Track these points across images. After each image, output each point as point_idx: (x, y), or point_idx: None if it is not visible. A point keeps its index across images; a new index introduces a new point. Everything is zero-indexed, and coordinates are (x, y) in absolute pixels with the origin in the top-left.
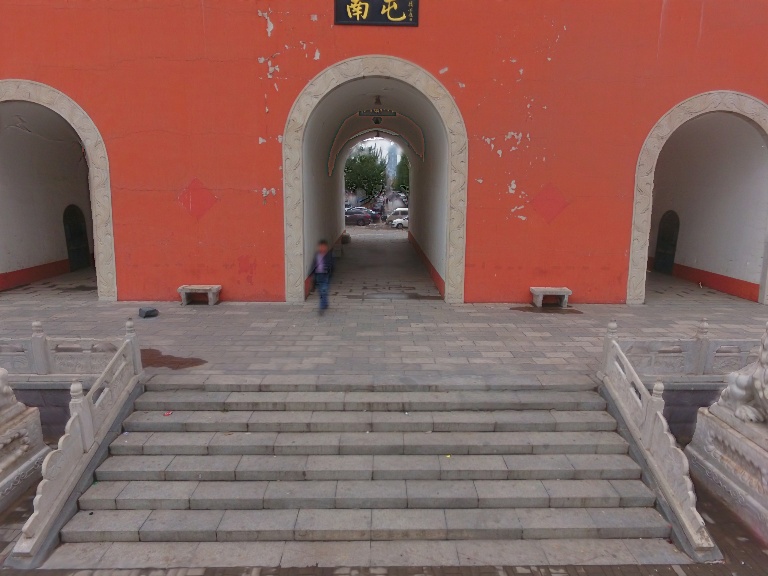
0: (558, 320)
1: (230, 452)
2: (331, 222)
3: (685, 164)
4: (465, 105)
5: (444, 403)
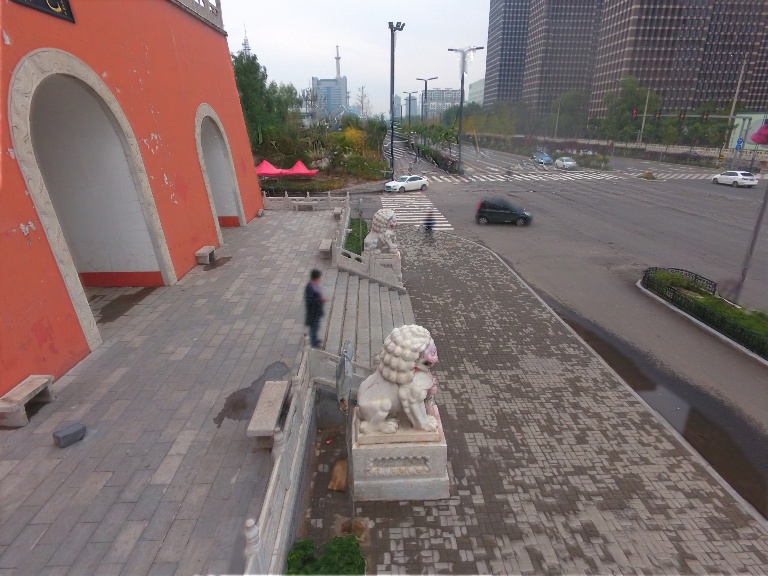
0: (243, 263)
1: None
2: None
3: None
4: (125, 109)
5: None
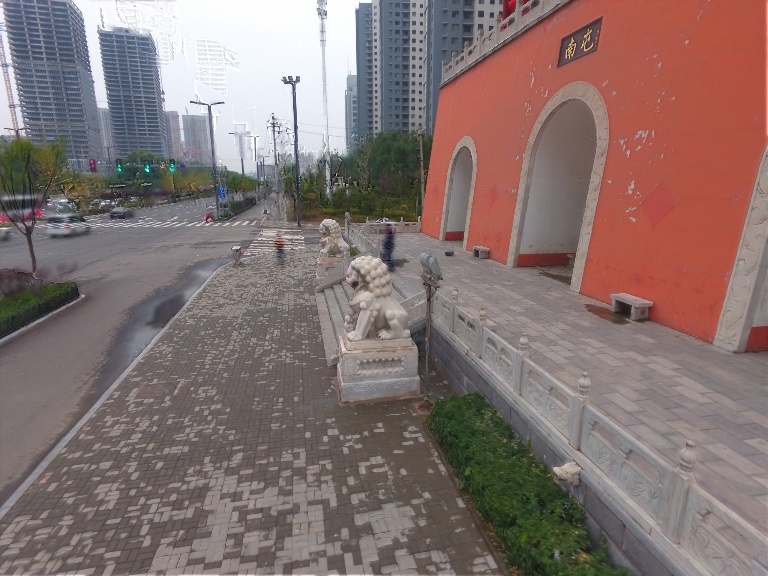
0: (571, 315)
1: None
2: None
3: None
4: (614, 111)
5: None
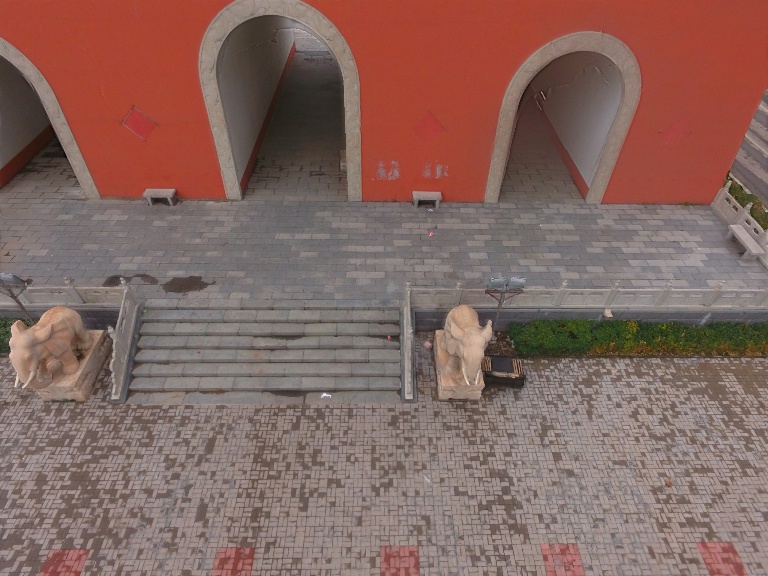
0: None
1: None
2: None
3: None
4: None
5: None
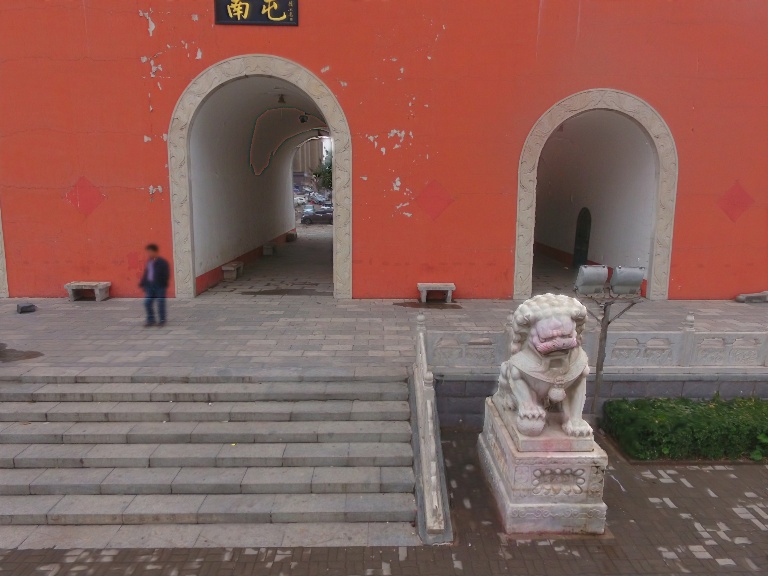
0: (430, 315)
1: (20, 441)
2: (261, 220)
3: (594, 162)
4: (347, 103)
5: (249, 394)
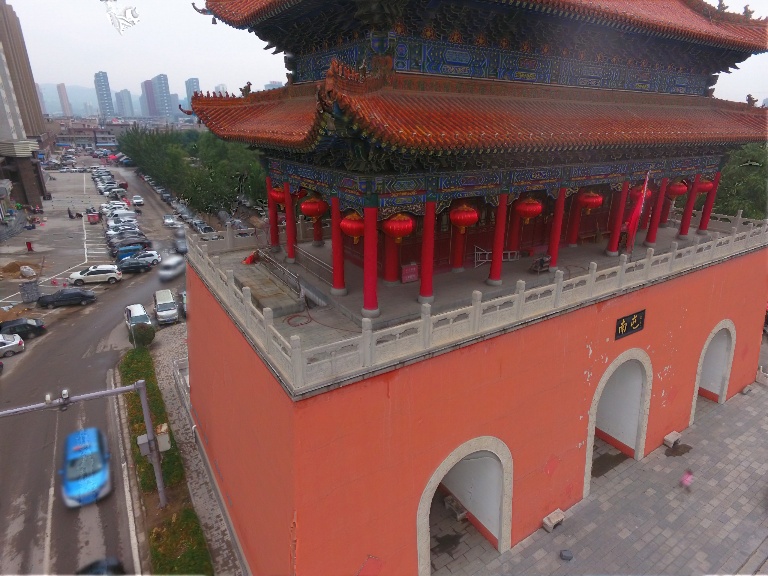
0: (697, 462)
1: None
2: None
3: None
4: (653, 361)
5: None
